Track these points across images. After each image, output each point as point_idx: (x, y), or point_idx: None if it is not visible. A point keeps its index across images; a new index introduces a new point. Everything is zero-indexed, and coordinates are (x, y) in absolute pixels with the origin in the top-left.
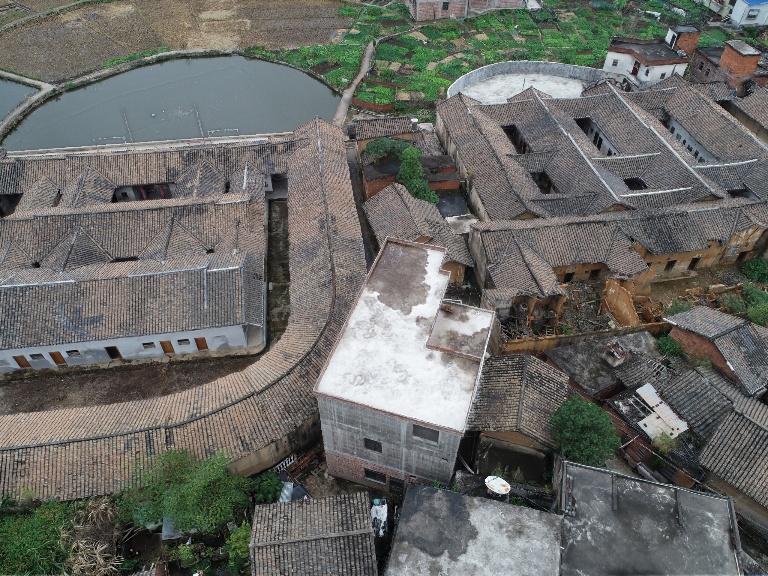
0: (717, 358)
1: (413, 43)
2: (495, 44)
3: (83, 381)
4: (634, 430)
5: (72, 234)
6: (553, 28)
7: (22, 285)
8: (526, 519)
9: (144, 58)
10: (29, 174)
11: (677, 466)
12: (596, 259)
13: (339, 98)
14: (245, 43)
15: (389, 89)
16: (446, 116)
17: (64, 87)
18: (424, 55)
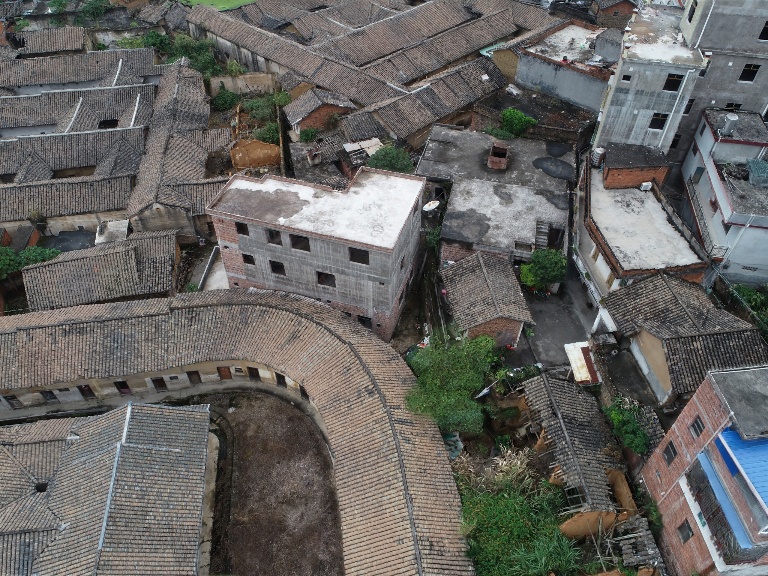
0: (332, 111)
1: None
2: None
3: None
4: None
5: None
6: None
7: None
8: (459, 189)
9: None
10: None
11: None
12: (204, 155)
13: None
14: None
15: None
16: None
17: None
18: None
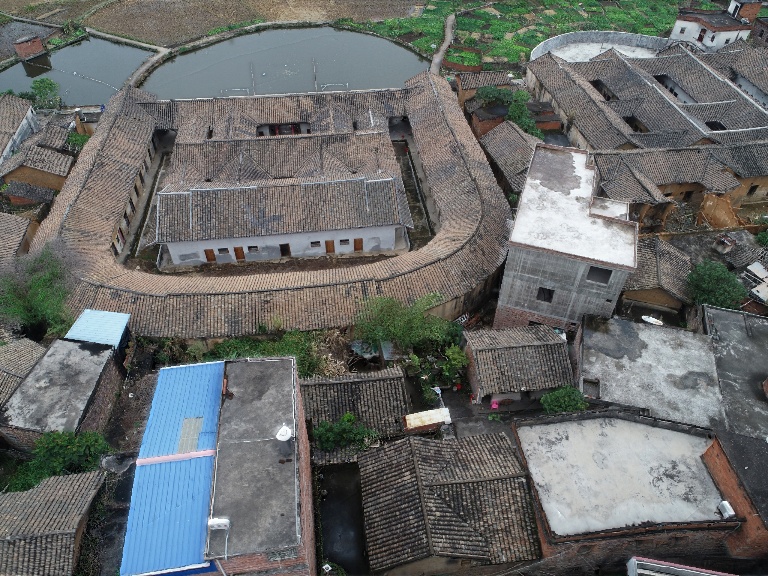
0: None
1: (488, 17)
2: (563, 18)
3: (267, 269)
4: (748, 295)
5: (237, 156)
6: (614, 6)
7: (214, 189)
8: (683, 337)
9: (244, 27)
10: (182, 113)
11: None
12: (693, 179)
13: (426, 63)
14: (333, 16)
15: (474, 54)
16: (538, 71)
17: (178, 50)
18: (500, 27)
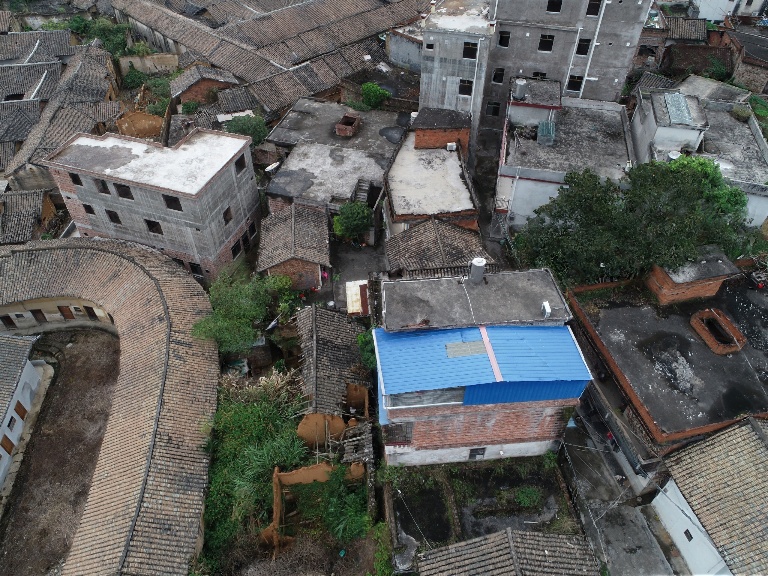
0: (212, 85)
1: None
2: None
3: (21, 522)
4: None
5: None
6: None
7: None
8: (298, 152)
9: None
10: None
11: (271, 122)
12: (91, 125)
13: None
14: None
15: None
16: None
17: None
18: None
